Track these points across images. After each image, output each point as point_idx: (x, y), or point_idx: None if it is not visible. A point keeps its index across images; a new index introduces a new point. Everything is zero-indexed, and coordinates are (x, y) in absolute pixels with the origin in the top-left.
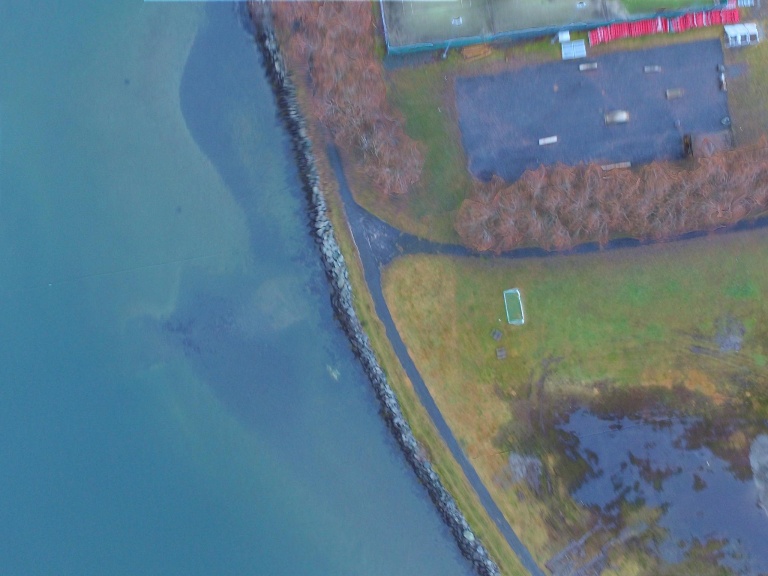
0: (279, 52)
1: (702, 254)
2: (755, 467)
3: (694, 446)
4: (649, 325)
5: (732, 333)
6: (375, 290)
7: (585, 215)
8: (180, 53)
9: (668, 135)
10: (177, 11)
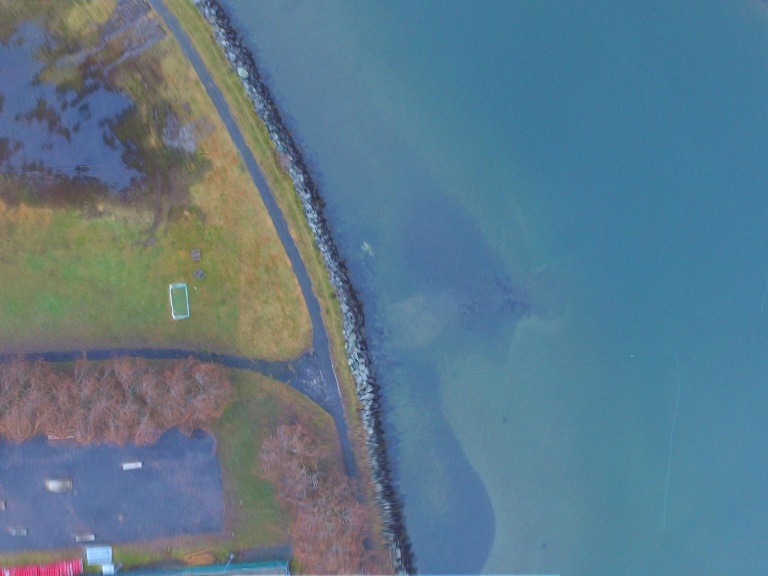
0: (396, 567)
1: None
2: None
3: (1, 141)
4: (40, 271)
5: None
6: (320, 328)
7: (97, 393)
8: (492, 570)
9: (7, 464)
10: None
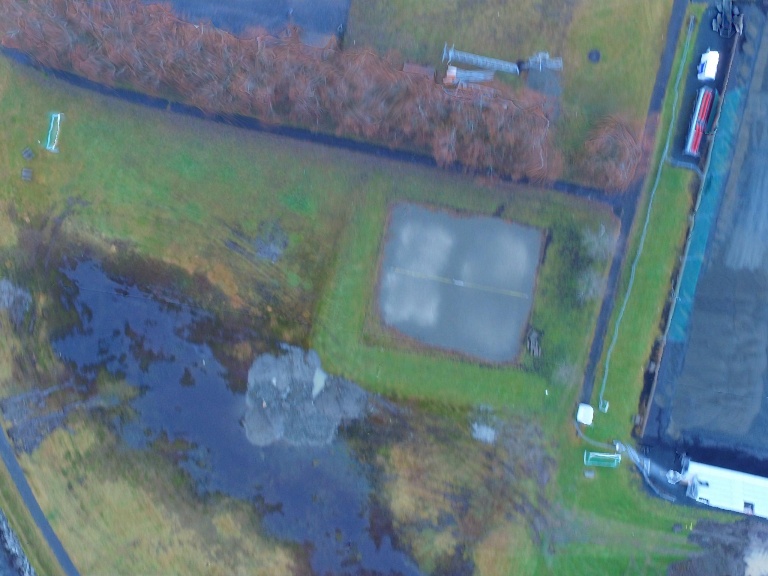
0: None
1: (270, 152)
2: (251, 383)
3: (196, 340)
4: (191, 202)
5: (274, 242)
6: None
7: (122, 48)
8: None
9: (277, 20)
10: None
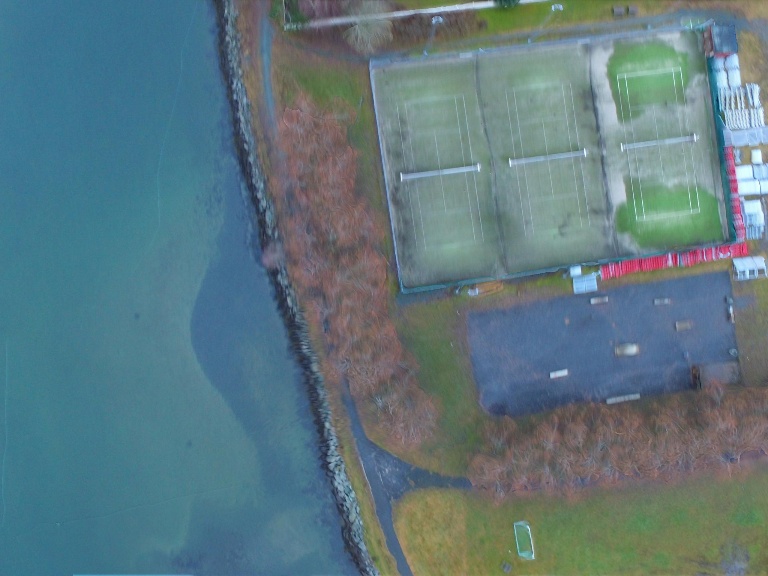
0: (291, 288)
1: (709, 483)
2: None
3: None
4: (656, 553)
5: (737, 559)
6: (386, 524)
7: (597, 468)
8: (191, 286)
9: (677, 366)
10: (188, 244)
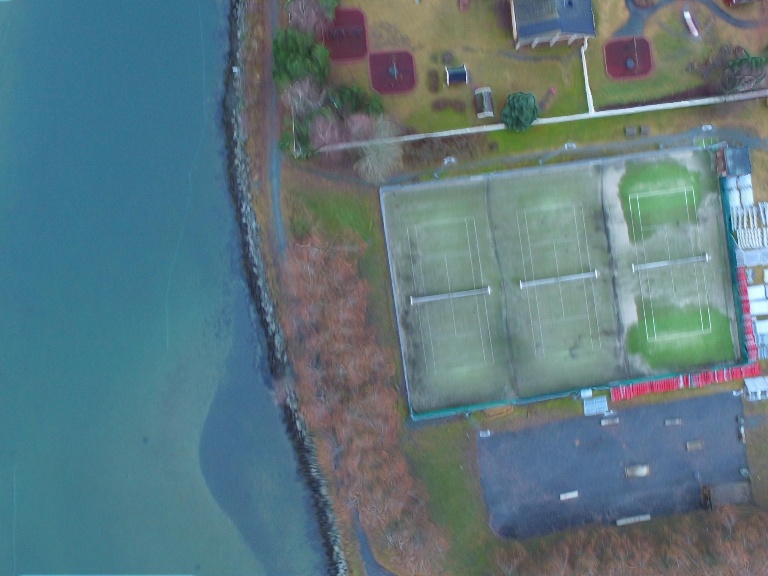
0: (300, 412)
1: None
2: None
3: None
4: None
5: None
6: None
7: None
8: (200, 410)
9: (687, 486)
10: (197, 367)
